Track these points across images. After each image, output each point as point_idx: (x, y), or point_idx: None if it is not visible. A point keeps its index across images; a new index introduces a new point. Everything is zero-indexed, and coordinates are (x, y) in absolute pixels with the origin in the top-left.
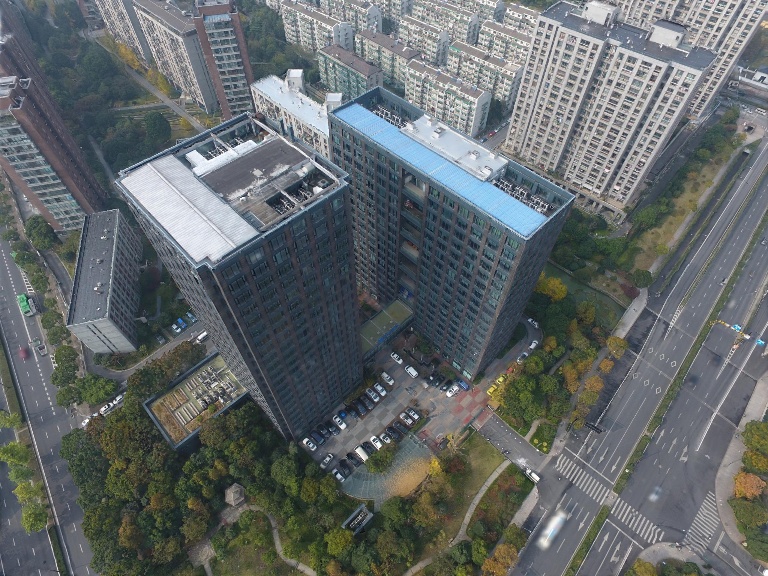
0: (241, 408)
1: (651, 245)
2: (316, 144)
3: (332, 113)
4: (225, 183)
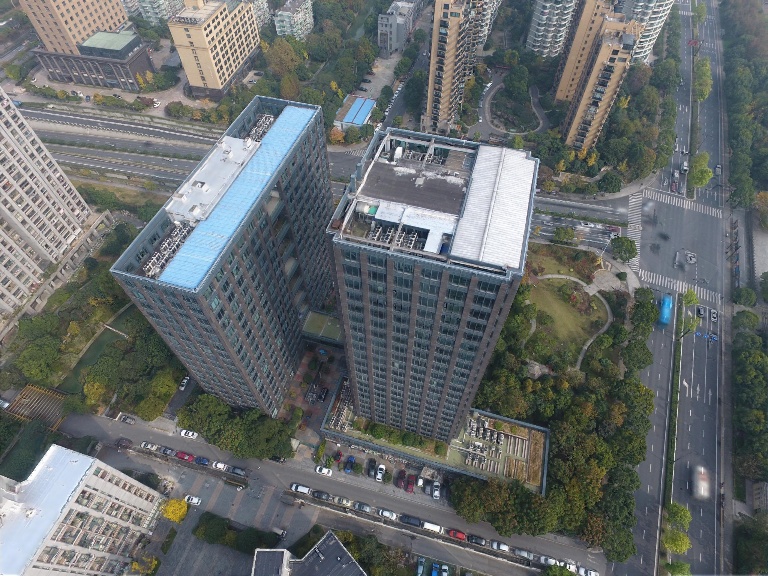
0: (484, 391)
1: (140, 197)
2: (90, 505)
3: (196, 288)
4: (449, 195)
